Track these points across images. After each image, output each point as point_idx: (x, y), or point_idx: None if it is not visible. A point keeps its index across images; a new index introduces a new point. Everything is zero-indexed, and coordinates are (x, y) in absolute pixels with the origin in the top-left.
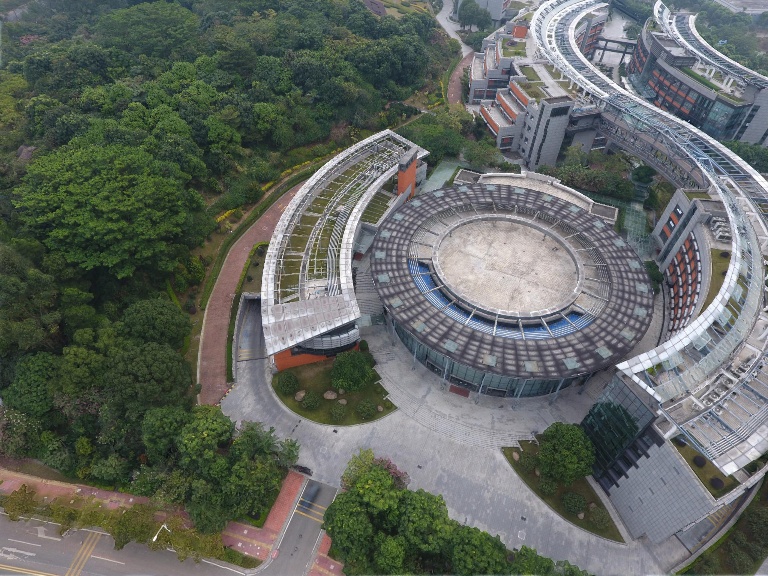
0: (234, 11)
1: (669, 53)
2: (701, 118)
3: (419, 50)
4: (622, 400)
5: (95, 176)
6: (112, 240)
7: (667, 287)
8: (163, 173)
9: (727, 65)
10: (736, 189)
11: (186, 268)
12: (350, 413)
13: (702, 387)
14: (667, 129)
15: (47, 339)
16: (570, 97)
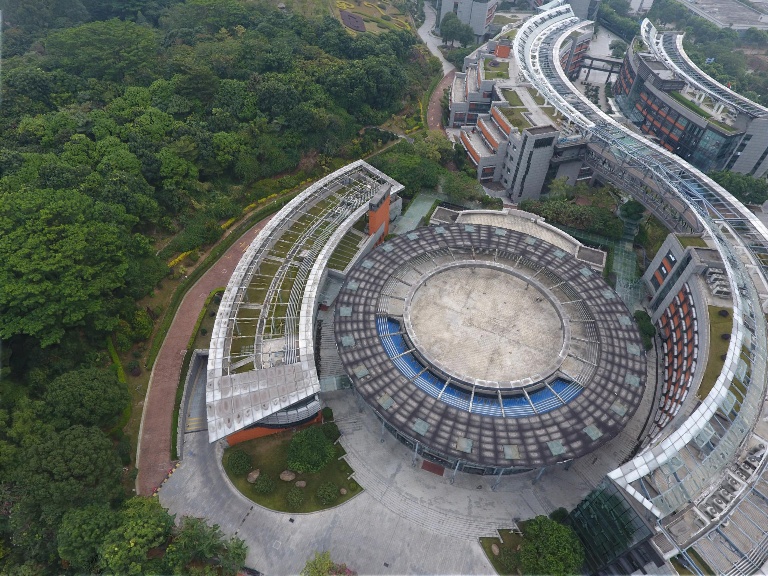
0: (199, 28)
1: (657, 76)
2: (691, 146)
3: (396, 72)
4: (614, 505)
5: (20, 226)
6: (35, 303)
7: (660, 340)
8: (104, 217)
9: (717, 90)
10: (733, 235)
11: (130, 324)
12: (309, 497)
13: (706, 494)
14: (657, 164)
15: None
16: (554, 127)
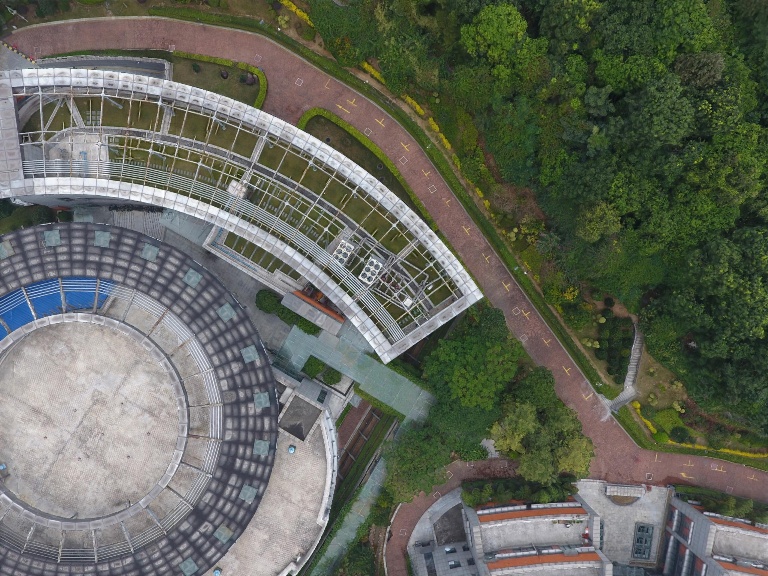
0: None
1: None
2: None
3: None
4: None
5: None
6: None
7: None
8: None
9: None
10: None
11: None
12: None
13: None
14: None
15: None
16: None
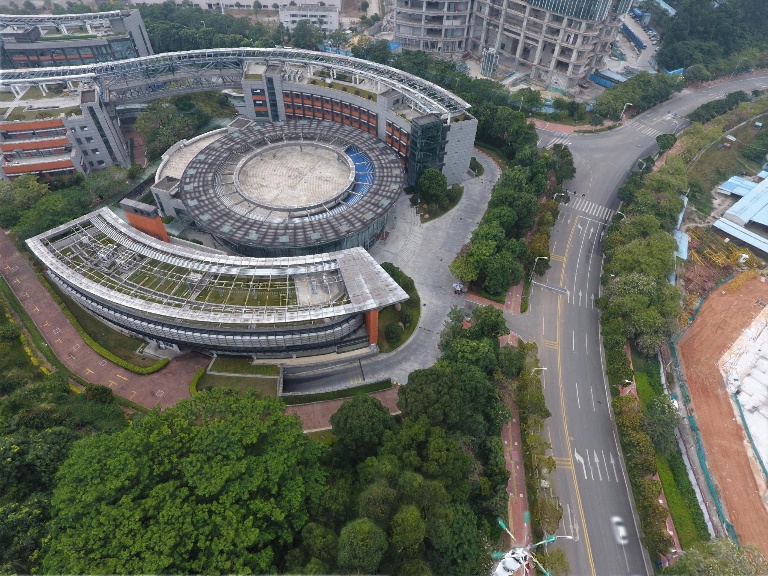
0: None
1: (15, 34)
2: None
3: None
4: None
5: None
6: None
7: None
8: None
9: None
10: None
11: None
12: None
13: None
14: None
15: None
16: (87, 90)
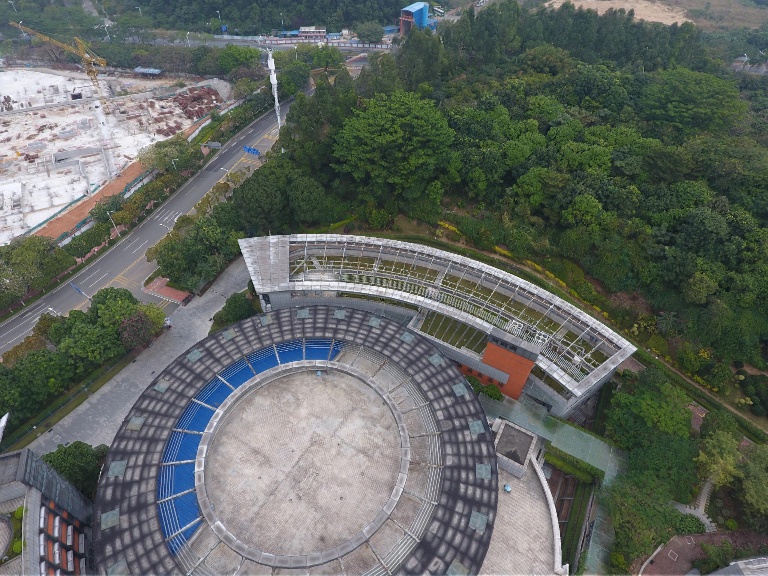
0: None
1: None
2: None
3: None
4: None
5: None
6: None
7: None
8: None
9: None
10: None
11: None
12: None
13: None
14: None
15: (293, 155)
16: None
